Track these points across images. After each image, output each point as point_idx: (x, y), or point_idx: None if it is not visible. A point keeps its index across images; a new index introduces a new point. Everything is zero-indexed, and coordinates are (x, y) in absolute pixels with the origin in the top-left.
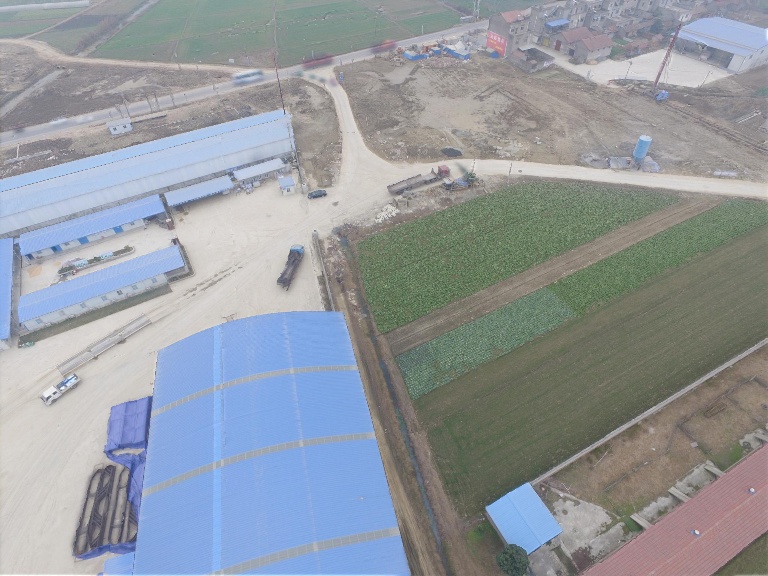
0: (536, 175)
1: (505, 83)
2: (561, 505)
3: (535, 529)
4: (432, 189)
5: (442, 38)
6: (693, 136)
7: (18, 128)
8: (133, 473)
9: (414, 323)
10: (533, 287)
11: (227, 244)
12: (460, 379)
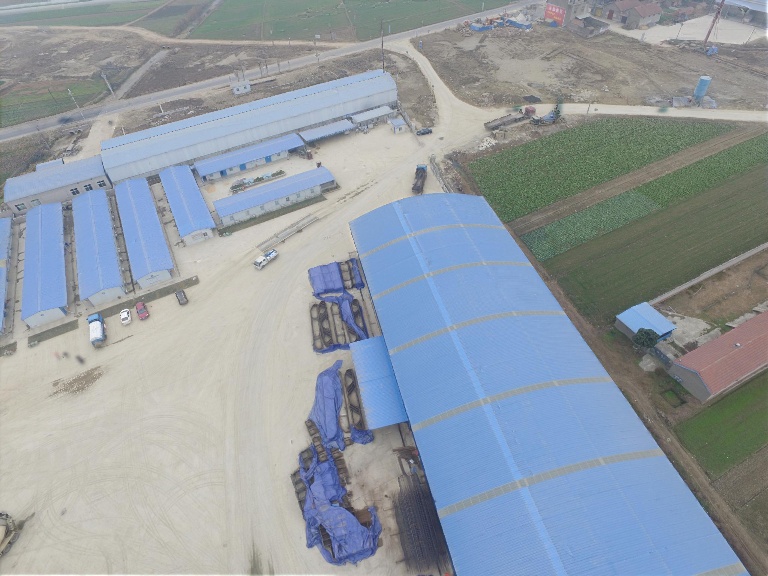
0: (609, 113)
1: (567, 47)
2: (670, 319)
3: (657, 325)
4: (522, 125)
5: (505, 11)
6: (743, 81)
7: (152, 92)
8: (341, 306)
9: (529, 215)
10: (622, 190)
11: (360, 168)
12: (575, 249)
